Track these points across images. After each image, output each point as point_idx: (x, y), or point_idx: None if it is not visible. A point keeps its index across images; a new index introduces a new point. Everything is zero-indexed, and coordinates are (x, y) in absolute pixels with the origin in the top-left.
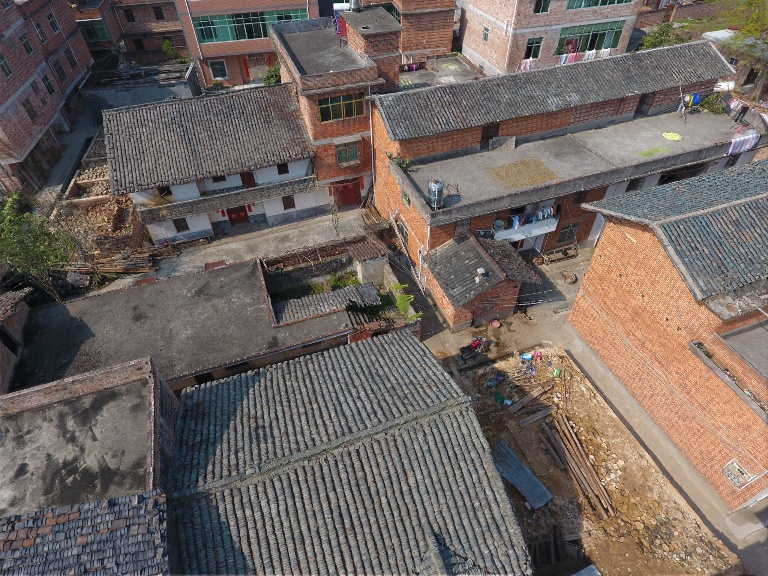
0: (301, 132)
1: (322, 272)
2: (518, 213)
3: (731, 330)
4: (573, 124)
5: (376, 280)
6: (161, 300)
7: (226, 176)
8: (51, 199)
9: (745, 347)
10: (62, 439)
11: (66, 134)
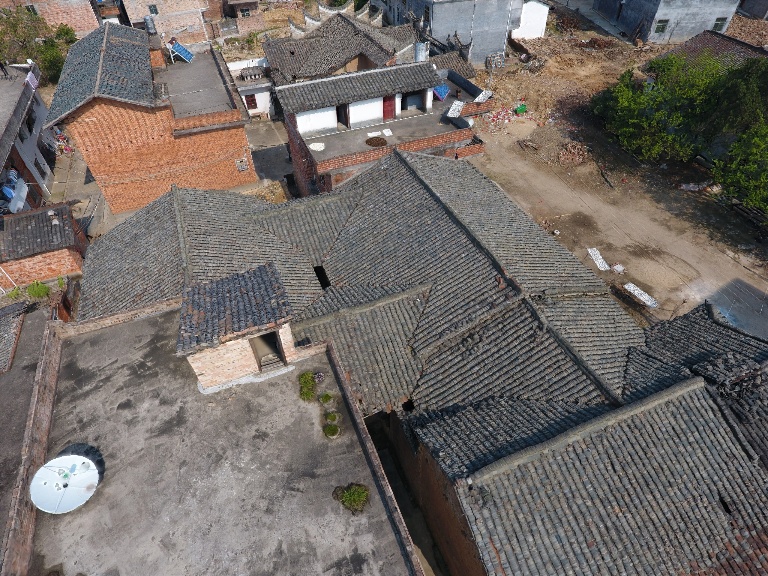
0: None
1: None
2: (2, 184)
3: None
4: None
5: None
6: None
7: None
8: None
9: None
10: (103, 387)
11: None
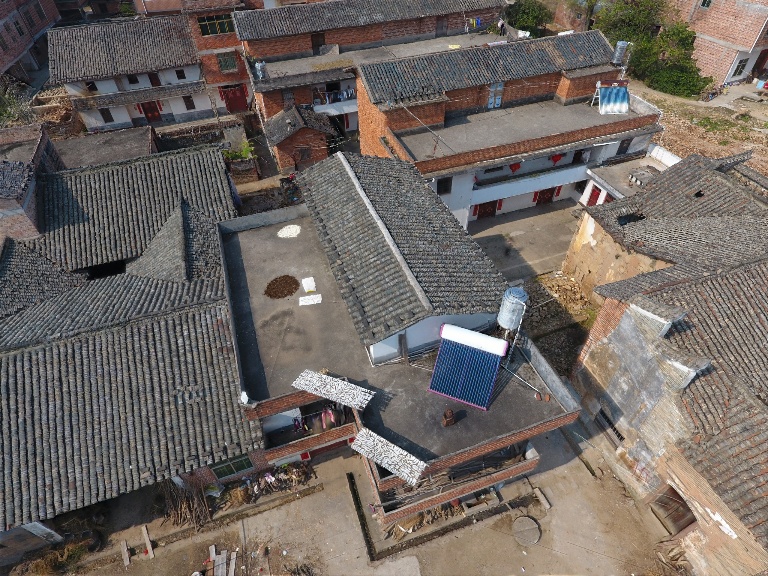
0: (193, 47)
1: (202, 142)
2: (327, 91)
3: (403, 129)
4: (385, 39)
5: (239, 147)
6: (78, 146)
7: (139, 79)
8: (6, 81)
9: (412, 140)
10: None
11: (35, 71)
